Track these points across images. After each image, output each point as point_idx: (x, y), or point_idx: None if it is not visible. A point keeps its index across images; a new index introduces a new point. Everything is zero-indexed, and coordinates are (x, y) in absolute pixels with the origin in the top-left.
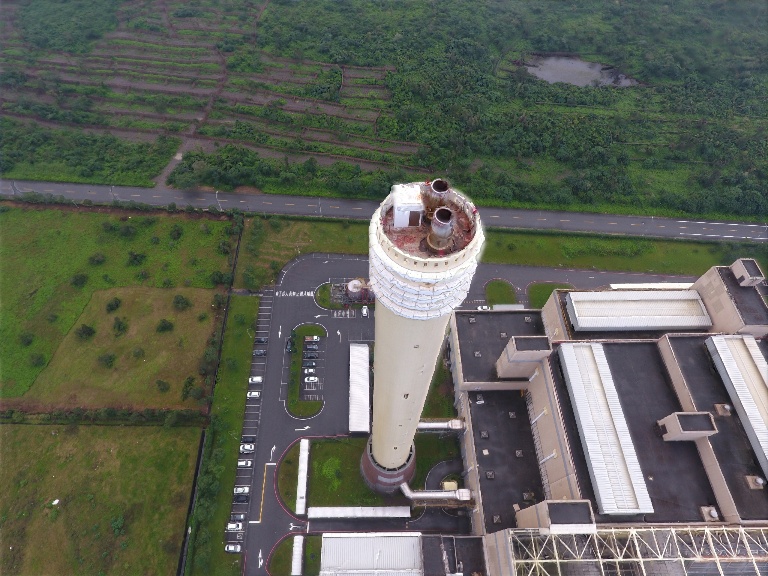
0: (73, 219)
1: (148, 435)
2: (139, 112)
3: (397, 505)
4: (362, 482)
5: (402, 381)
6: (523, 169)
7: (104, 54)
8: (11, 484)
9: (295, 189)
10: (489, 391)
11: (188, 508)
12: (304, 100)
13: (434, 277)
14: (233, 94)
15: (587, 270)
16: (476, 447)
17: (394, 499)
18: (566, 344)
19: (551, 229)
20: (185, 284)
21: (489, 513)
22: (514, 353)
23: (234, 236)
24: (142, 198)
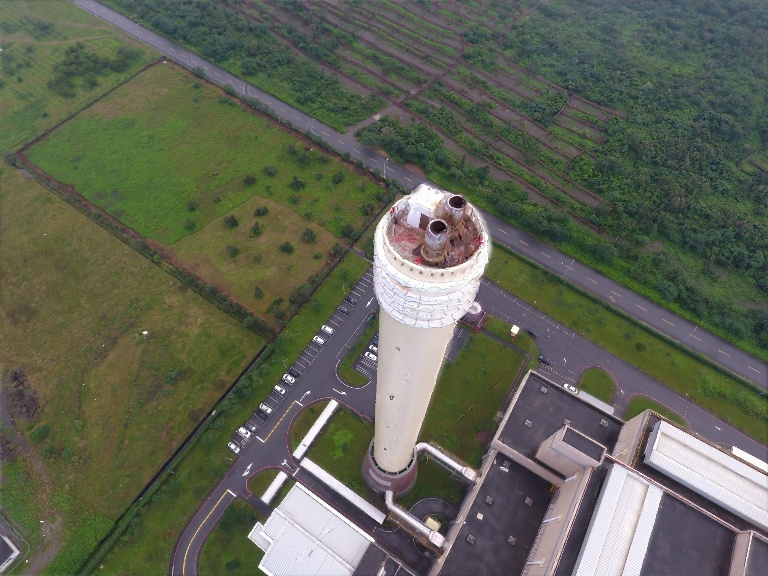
0: (272, 132)
1: (228, 323)
2: (368, 67)
3: (376, 507)
4: (360, 467)
5: (388, 379)
6: (708, 276)
7: (369, 9)
8: (128, 302)
9: (456, 187)
10: (520, 465)
11: (222, 396)
12: (514, 112)
13: (406, 280)
14: (453, 82)
15: (717, 417)
16: (474, 505)
17: (377, 500)
18: (621, 467)
19: (700, 353)
20: (320, 223)
21: (448, 571)
22: (558, 441)
23: (381, 203)
24: (329, 138)
